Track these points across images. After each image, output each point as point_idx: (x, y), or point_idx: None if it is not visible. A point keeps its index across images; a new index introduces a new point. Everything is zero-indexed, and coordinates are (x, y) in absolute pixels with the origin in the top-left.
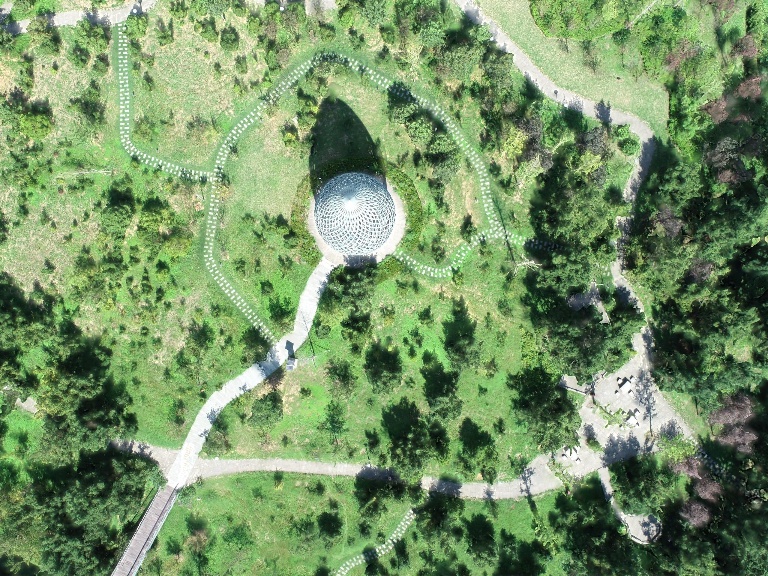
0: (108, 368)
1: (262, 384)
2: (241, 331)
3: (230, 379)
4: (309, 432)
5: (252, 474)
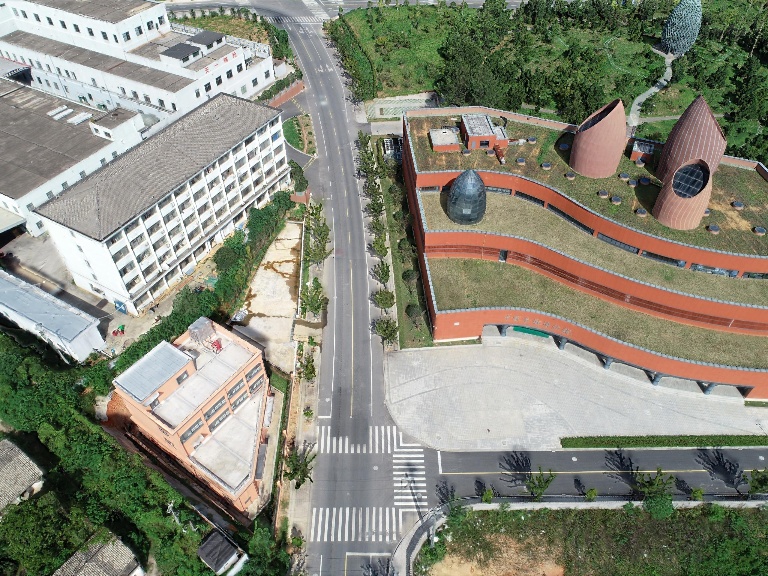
0: None
1: (659, 91)
2: (641, 79)
3: (643, 93)
4: None
5: (670, 120)
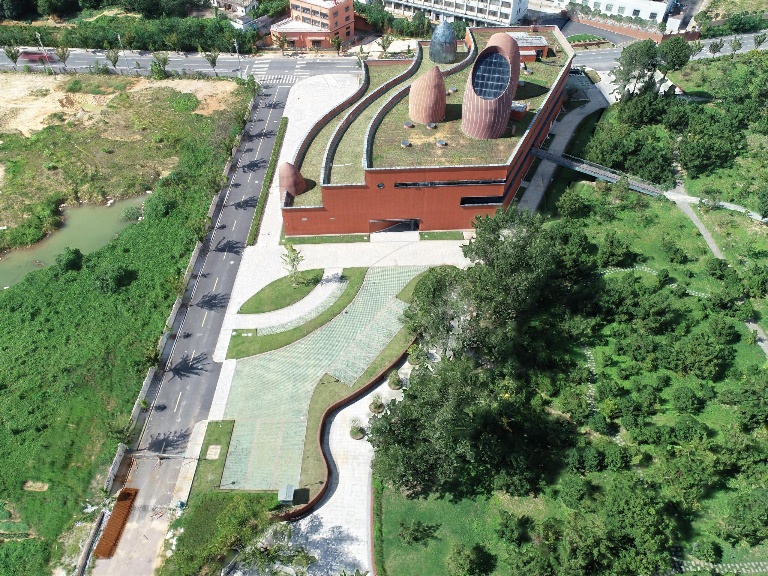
0: (720, 168)
1: None
2: None
3: (751, 210)
4: (740, 244)
5: (693, 223)
